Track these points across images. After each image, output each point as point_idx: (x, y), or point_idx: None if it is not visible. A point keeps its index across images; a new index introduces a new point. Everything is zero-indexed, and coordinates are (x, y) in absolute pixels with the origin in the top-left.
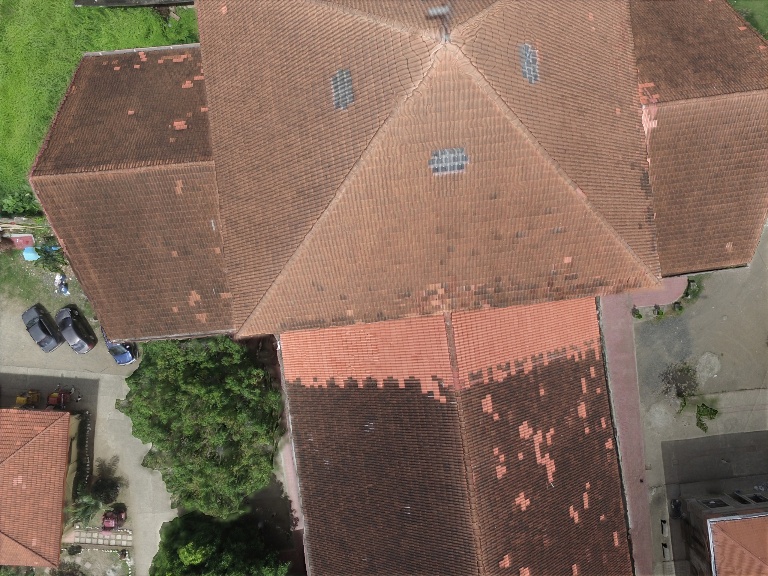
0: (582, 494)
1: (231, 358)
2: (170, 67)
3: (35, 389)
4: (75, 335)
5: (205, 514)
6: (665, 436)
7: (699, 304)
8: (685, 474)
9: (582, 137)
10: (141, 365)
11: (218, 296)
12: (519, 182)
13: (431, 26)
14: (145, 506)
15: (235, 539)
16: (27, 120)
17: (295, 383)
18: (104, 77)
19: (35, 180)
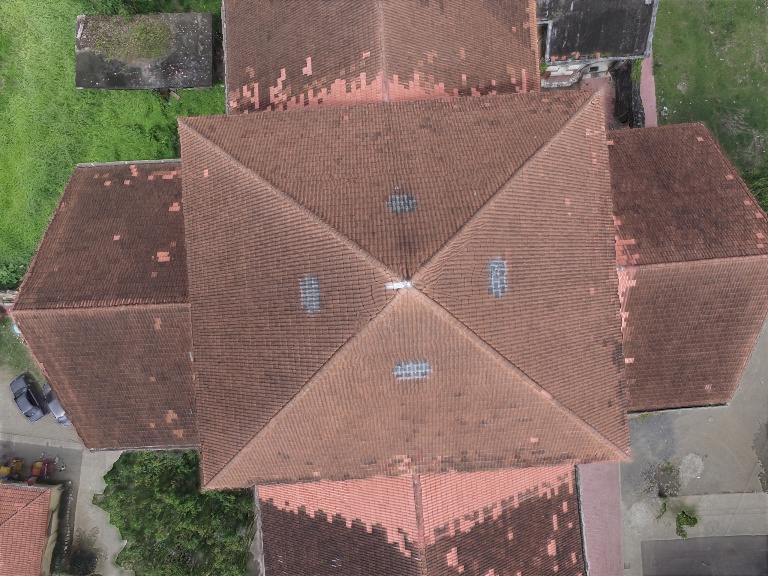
0: None
1: None
2: (159, 185)
3: (20, 457)
4: (61, 407)
5: None
6: (645, 536)
7: None
8: (664, 575)
9: (551, 332)
10: (120, 460)
11: (195, 415)
12: (483, 385)
13: (394, 263)
14: None
15: None
16: (25, 191)
17: (268, 502)
18: (93, 194)
19: (16, 314)
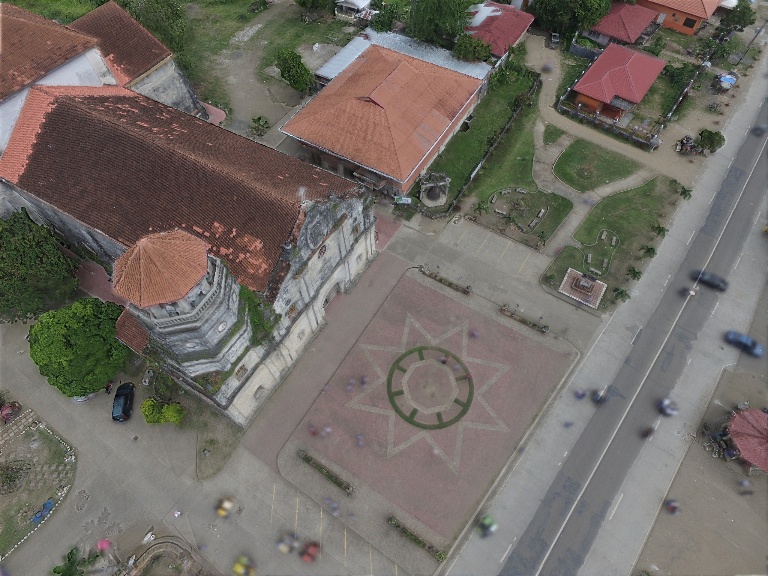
0: (162, 114)
1: None
2: None
3: None
4: None
5: (28, 273)
6: None
7: (235, 112)
8: (293, 152)
9: None
10: None
11: None
12: None
13: None
14: (30, 390)
15: None
16: None
17: (19, 179)
18: None
19: None
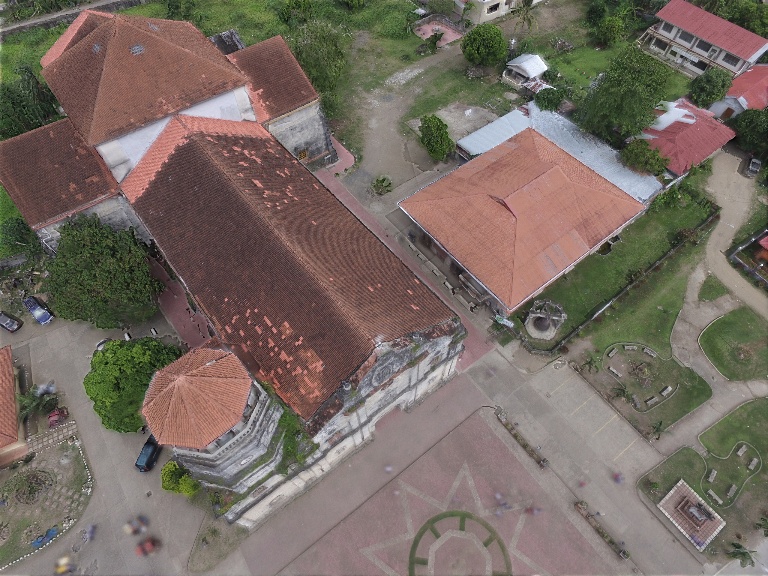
0: None
1: None
2: None
3: None
4: (7, 319)
5: (111, 298)
6: (385, 213)
7: (364, 161)
8: (407, 223)
9: None
10: None
11: (84, 182)
12: None
13: None
14: (81, 400)
15: None
16: None
17: (136, 200)
18: None
19: None
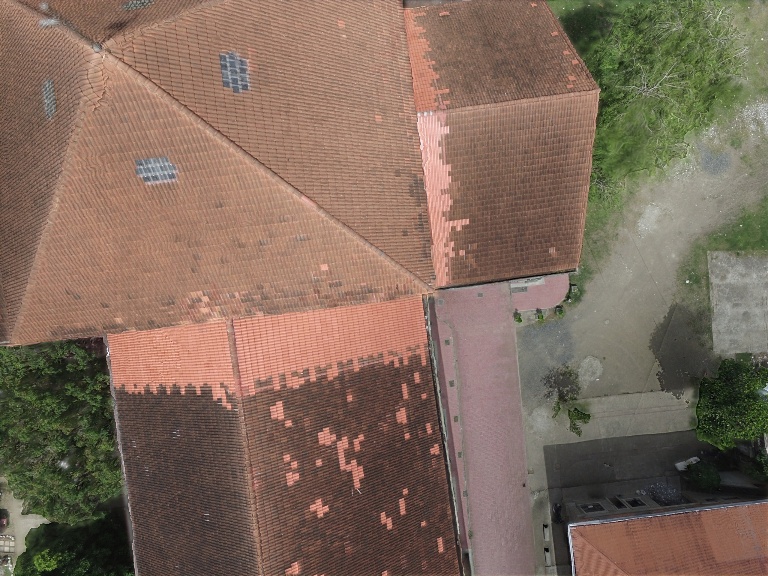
0: (398, 500)
1: (76, 364)
2: None
3: None
4: None
5: None
6: (547, 440)
7: (581, 308)
8: (568, 478)
9: (318, 145)
10: None
11: None
12: (239, 191)
13: (98, 37)
14: None
15: (101, 545)
16: None
17: (121, 390)
18: None
19: None
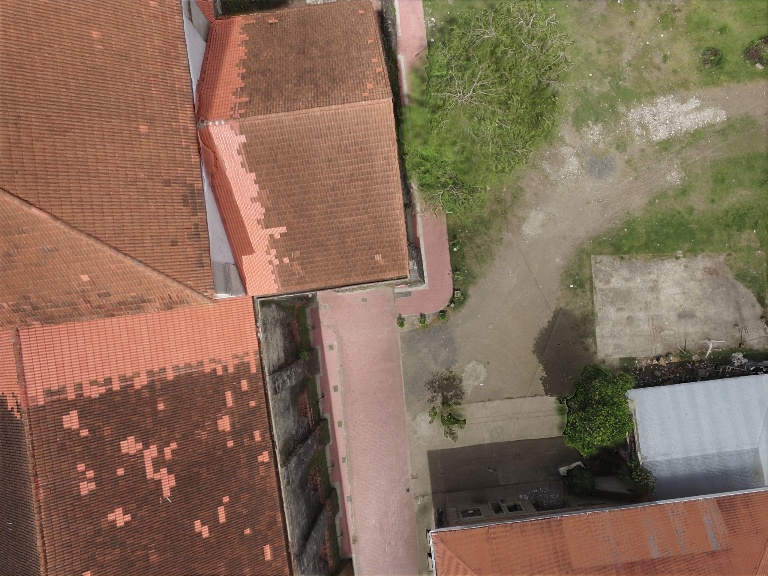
0: (216, 508)
1: None
2: None
3: None
4: None
5: None
6: (431, 445)
7: (465, 312)
8: (451, 483)
9: (59, 157)
10: None
11: None
12: None
13: None
14: None
15: None
16: None
17: None
18: None
19: None
